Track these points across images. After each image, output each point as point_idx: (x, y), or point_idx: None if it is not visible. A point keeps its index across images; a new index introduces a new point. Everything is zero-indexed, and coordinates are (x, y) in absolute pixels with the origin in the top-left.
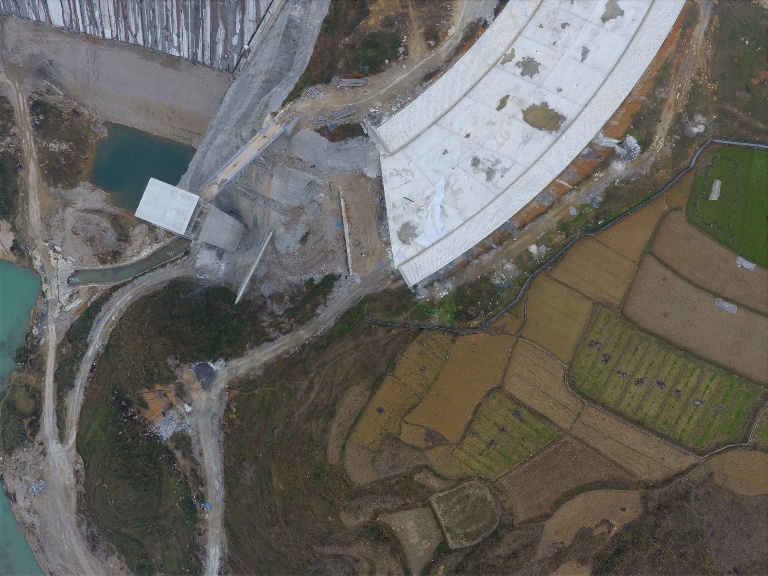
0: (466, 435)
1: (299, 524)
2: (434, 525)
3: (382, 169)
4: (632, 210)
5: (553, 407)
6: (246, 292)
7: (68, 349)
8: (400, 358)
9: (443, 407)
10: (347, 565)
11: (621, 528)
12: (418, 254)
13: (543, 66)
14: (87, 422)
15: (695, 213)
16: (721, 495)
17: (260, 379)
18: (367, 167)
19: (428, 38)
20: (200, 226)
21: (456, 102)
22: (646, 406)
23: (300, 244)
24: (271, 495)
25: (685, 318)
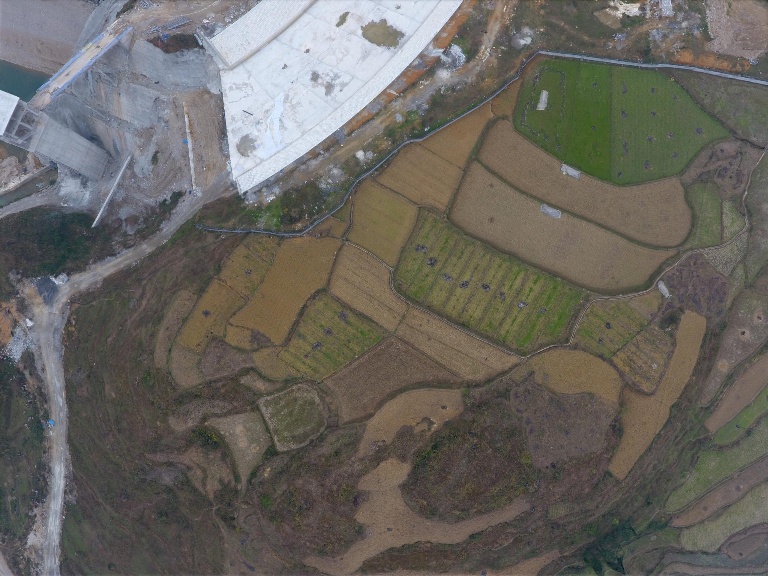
0: (292, 337)
1: (131, 432)
2: (263, 429)
3: (222, 83)
4: (456, 117)
5: (378, 309)
6: (104, 216)
7: None
8: (226, 261)
9: (268, 309)
10: (181, 473)
11: (441, 425)
12: (256, 166)
13: None
14: None
15: (523, 123)
16: (540, 393)
17: (98, 290)
18: (210, 83)
19: None
20: (30, 133)
21: (295, 18)
22: (471, 308)
23: (153, 165)
24: (103, 403)
25: (511, 223)
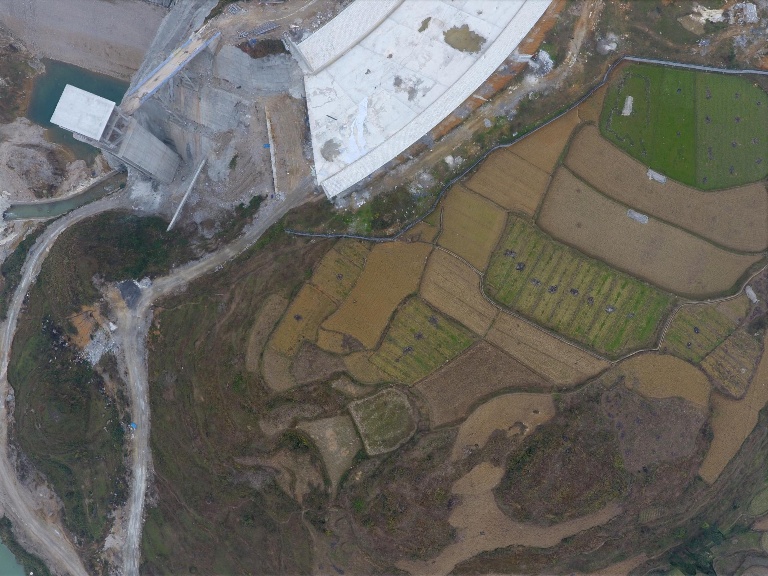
0: (383, 342)
1: (220, 435)
2: (353, 433)
3: (306, 88)
4: (545, 122)
5: (468, 314)
6: (178, 220)
7: (2, 282)
8: (318, 266)
9: (360, 313)
10: (268, 477)
11: (534, 430)
12: (341, 171)
13: None
14: (18, 352)
15: (608, 128)
16: (631, 397)
17: (183, 294)
18: (292, 88)
19: None
20: (120, 138)
21: (378, 23)
22: (560, 313)
23: (230, 169)
24: (192, 407)
25: (598, 228)
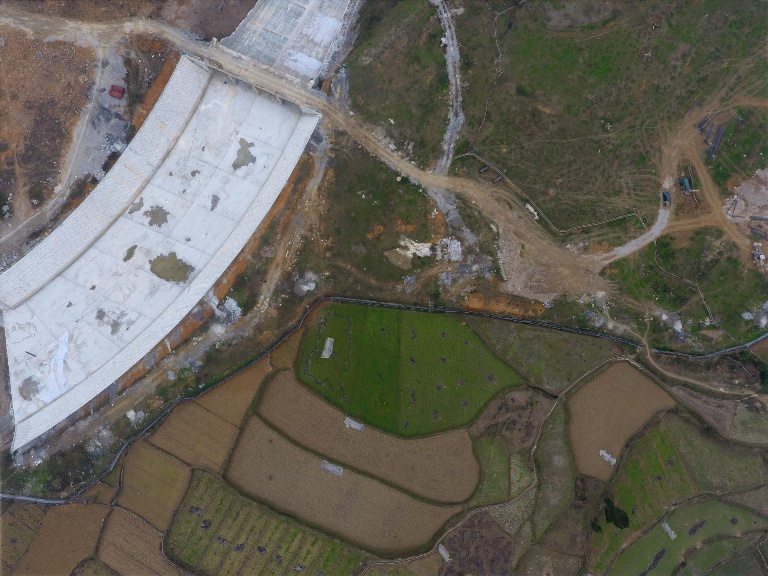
0: None
1: None
2: None
3: (4, 323)
4: (230, 375)
5: None
6: None
7: None
8: None
9: None
10: None
11: None
12: (39, 410)
13: (172, 215)
14: None
15: (306, 372)
16: None
17: None
18: None
19: (31, 197)
20: None
21: (80, 254)
22: (246, 573)
23: None
24: None
25: (290, 481)
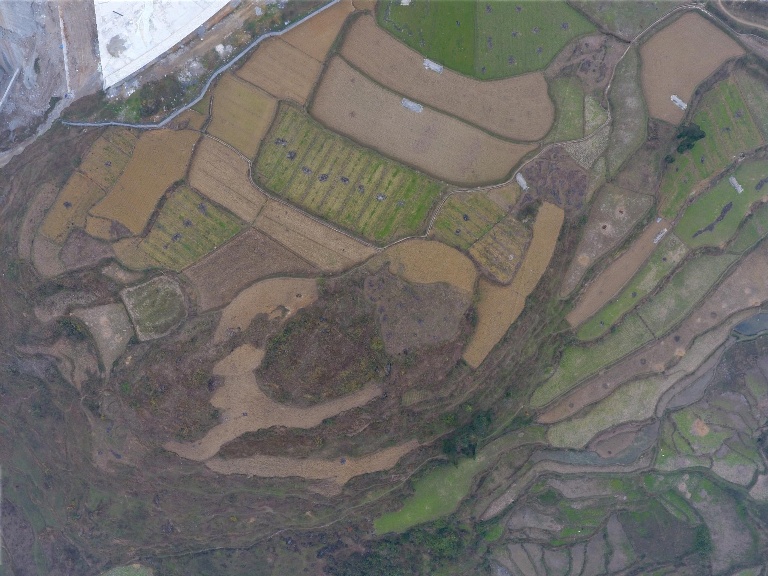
0: (152, 229)
1: (1, 324)
2: (127, 320)
3: None
4: None
5: (237, 201)
6: None
7: None
8: (86, 153)
9: (127, 200)
10: None
11: (295, 313)
12: None
13: None
14: None
15: (387, 18)
16: (394, 281)
17: None
18: None
19: None
20: None
21: None
22: (330, 201)
23: (36, 74)
24: None
25: (372, 118)
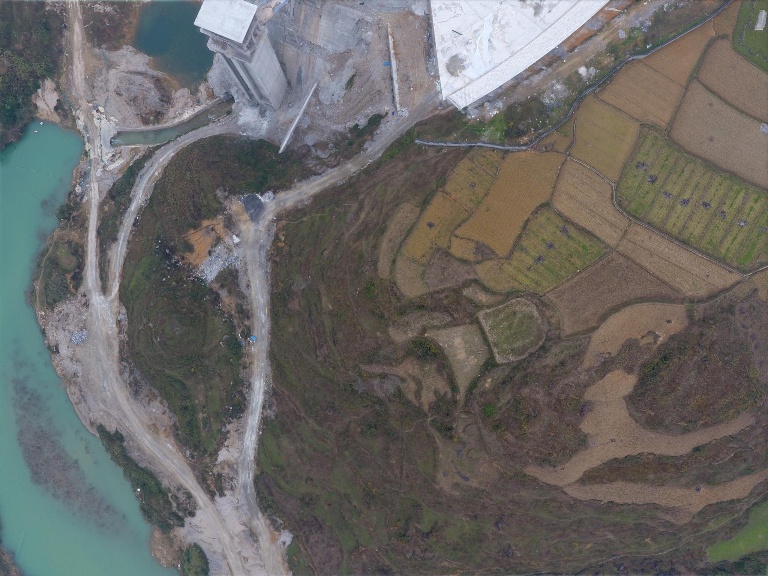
0: (515, 250)
1: (347, 343)
2: (481, 342)
3: (431, 3)
4: (680, 33)
5: (600, 224)
6: (290, 143)
7: (111, 206)
8: (451, 174)
9: (493, 221)
10: (393, 385)
11: (667, 339)
12: (466, 85)
13: None
14: (130, 272)
15: (741, 43)
16: (765, 309)
17: (309, 206)
18: (416, 4)
19: None
20: (255, 46)
21: None
22: (691, 226)
23: (346, 90)
24: (320, 315)
25: (730, 143)
